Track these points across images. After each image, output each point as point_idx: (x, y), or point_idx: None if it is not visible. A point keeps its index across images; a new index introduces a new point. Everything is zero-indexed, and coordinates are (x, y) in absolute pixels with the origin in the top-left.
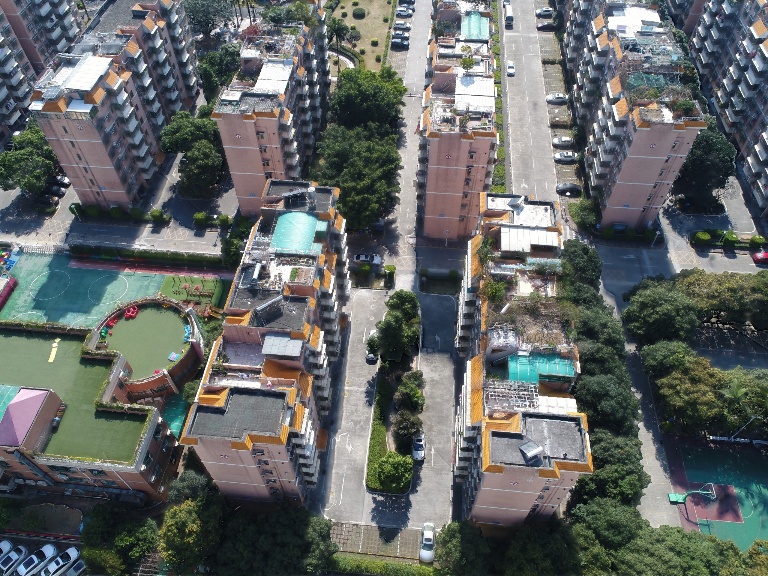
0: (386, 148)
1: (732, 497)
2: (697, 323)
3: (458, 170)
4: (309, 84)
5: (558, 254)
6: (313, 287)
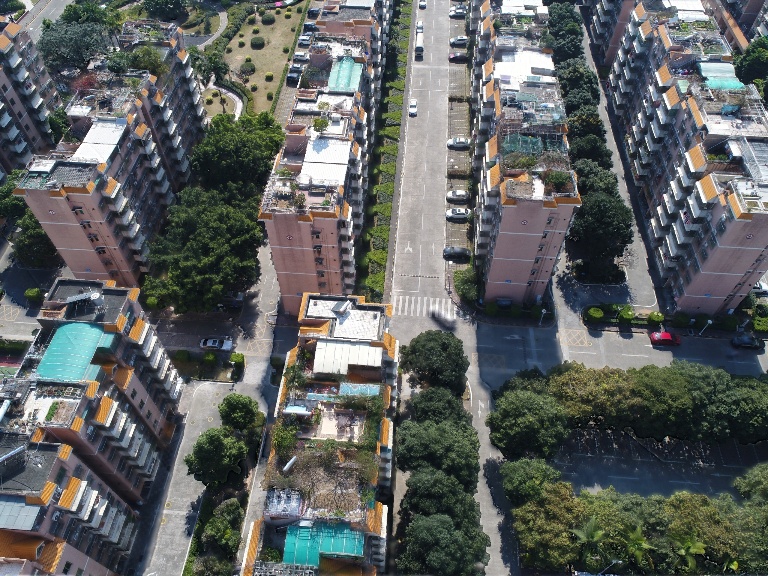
0: (241, 215)
1: None
2: (566, 435)
3: (304, 251)
4: (165, 137)
5: (393, 366)
6: (71, 429)
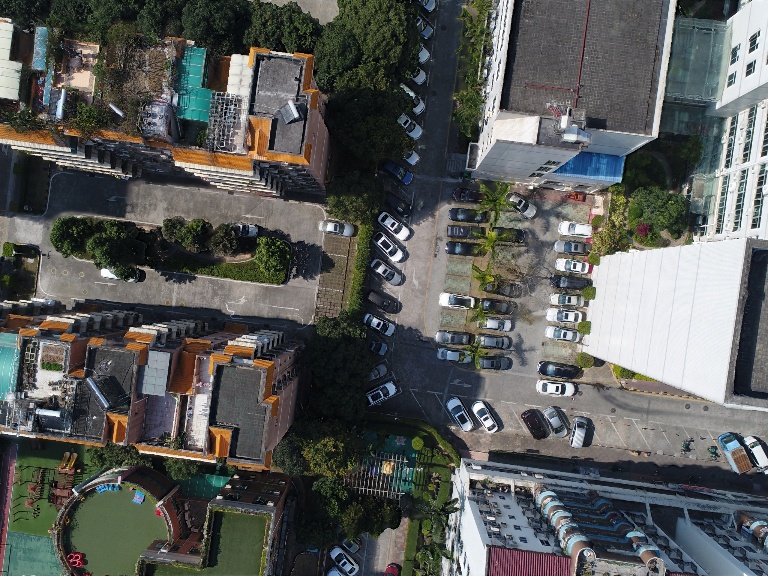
0: None
1: None
2: None
3: None
4: None
5: None
6: (73, 342)
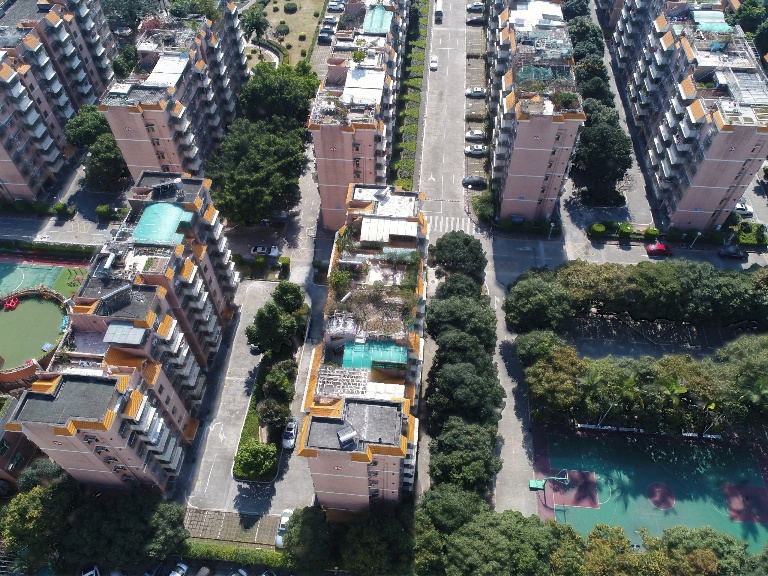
0: (286, 141)
1: (591, 483)
2: (571, 313)
3: (345, 162)
4: (217, 78)
5: (425, 244)
6: (165, 276)
